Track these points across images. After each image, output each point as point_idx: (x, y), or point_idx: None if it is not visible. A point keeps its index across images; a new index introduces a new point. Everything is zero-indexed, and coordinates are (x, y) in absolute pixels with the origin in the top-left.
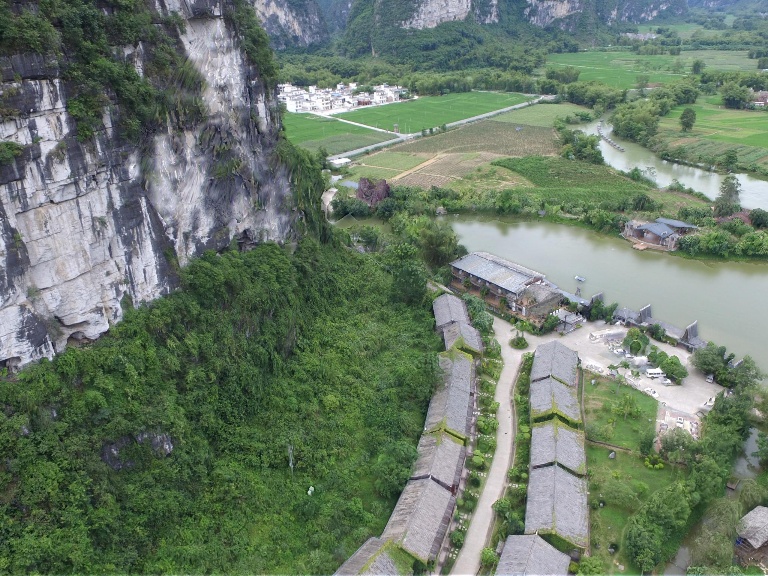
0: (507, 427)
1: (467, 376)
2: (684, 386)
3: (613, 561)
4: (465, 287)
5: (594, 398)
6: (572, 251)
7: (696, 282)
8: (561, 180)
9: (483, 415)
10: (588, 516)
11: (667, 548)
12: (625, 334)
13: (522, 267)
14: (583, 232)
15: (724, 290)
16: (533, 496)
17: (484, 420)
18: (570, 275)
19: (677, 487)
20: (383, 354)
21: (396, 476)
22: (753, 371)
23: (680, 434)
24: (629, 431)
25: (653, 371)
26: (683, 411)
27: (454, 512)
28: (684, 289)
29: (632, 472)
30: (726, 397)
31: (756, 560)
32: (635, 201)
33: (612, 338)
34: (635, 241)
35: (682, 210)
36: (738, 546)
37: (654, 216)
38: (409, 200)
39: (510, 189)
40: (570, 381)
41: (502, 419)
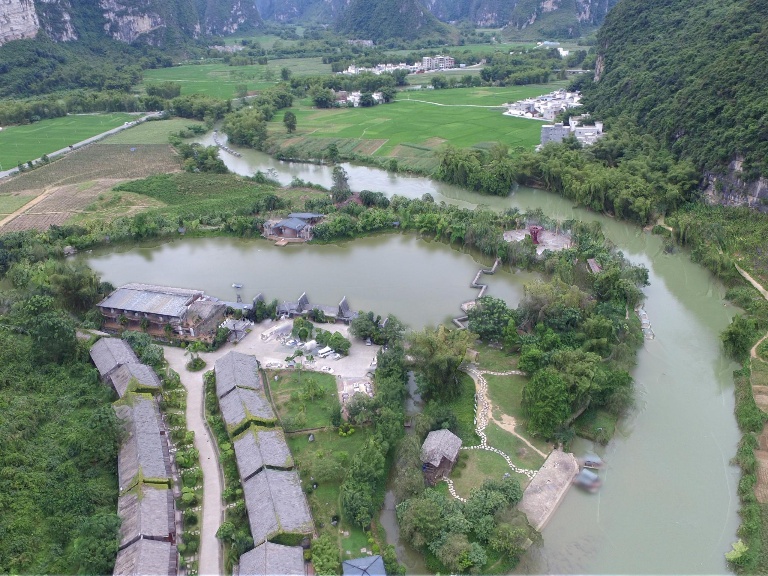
0: (208, 452)
1: (152, 417)
2: (351, 355)
3: (338, 532)
4: (122, 325)
5: (281, 393)
6: (222, 261)
7: (335, 263)
8: (192, 195)
9: (180, 450)
10: (306, 502)
11: (376, 498)
12: (291, 325)
13: (177, 289)
14: (227, 241)
15: (358, 264)
16: (253, 507)
17: (183, 454)
18: (227, 285)
19: (369, 443)
20: (44, 427)
21: (101, 554)
22: (397, 325)
23: (359, 397)
24: (319, 411)
25: (323, 351)
26: (356, 377)
27: (179, 561)
28: (328, 272)
29: (331, 446)
30: (384, 353)
31: (440, 476)
32: (266, 202)
33: (281, 333)
34: (276, 239)
35: (307, 203)
36: (425, 471)
37: (286, 213)
38: (26, 247)
39: (142, 213)
40: (256, 385)
41: (201, 446)
